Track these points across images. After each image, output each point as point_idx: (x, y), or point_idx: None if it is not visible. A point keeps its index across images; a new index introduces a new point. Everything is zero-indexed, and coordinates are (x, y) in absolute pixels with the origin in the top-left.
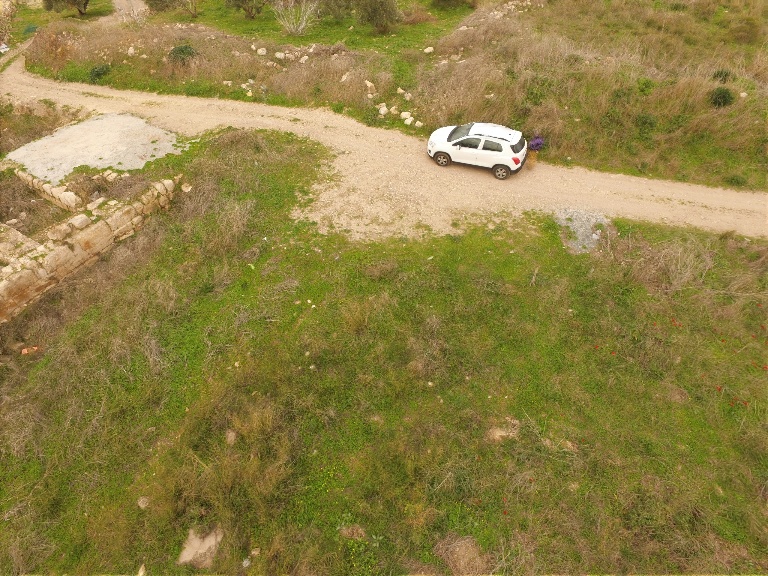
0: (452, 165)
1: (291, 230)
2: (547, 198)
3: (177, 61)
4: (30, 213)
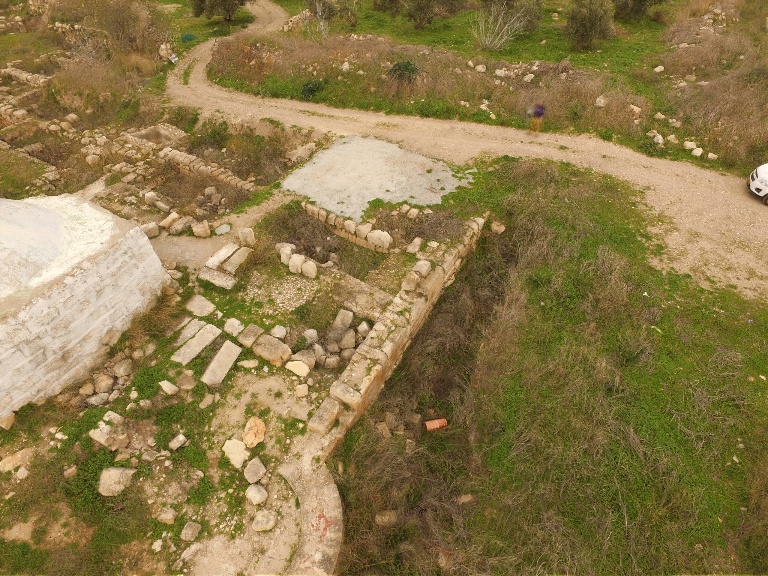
0: None
1: (667, 284)
2: None
3: (403, 79)
4: (339, 254)
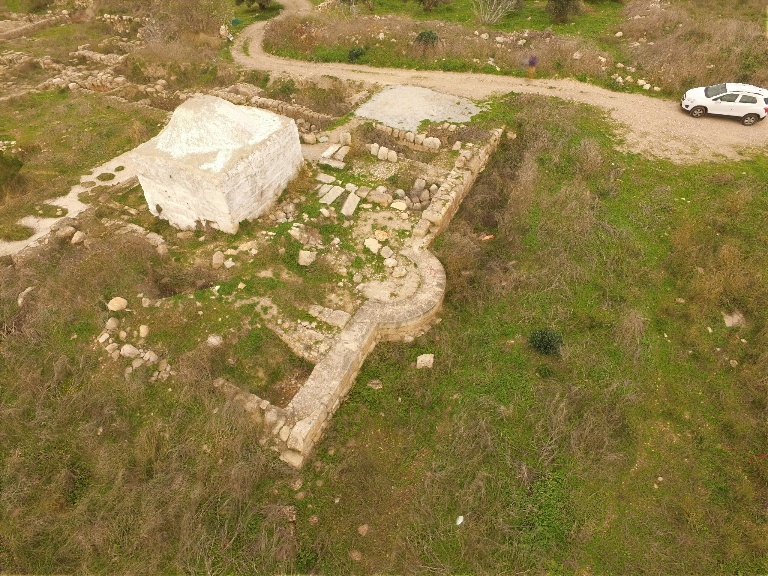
0: (703, 117)
1: (626, 159)
2: None
3: (428, 44)
4: (405, 153)
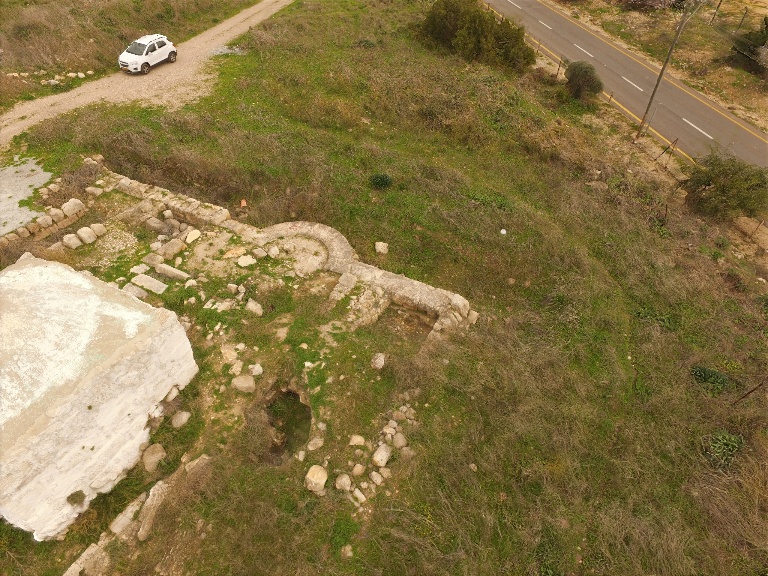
0: None
1: (189, 111)
2: (200, 55)
3: None
4: None
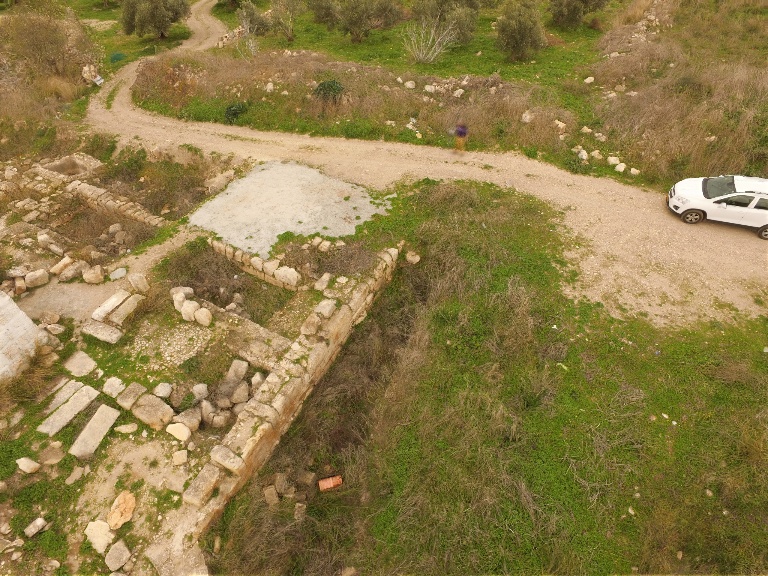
0: (701, 222)
1: (578, 314)
2: None
3: (328, 99)
4: (244, 294)
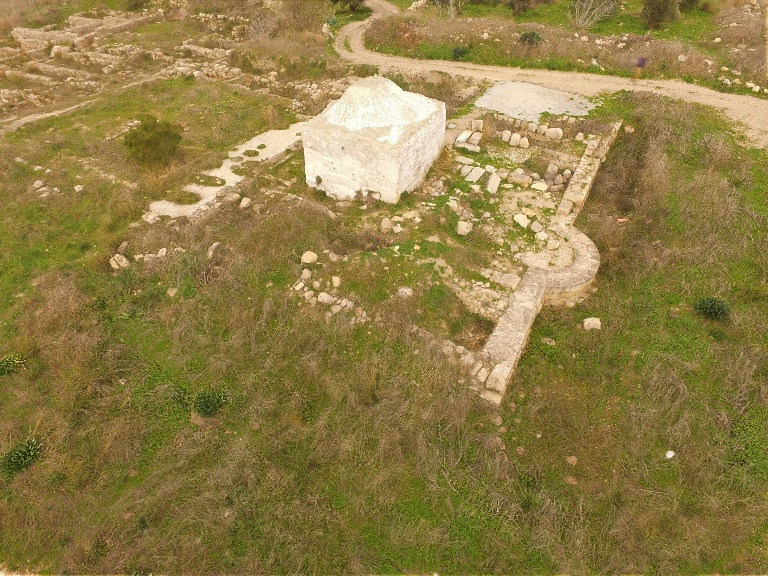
0: None
1: (751, 153)
2: None
3: (532, 44)
4: (529, 142)
